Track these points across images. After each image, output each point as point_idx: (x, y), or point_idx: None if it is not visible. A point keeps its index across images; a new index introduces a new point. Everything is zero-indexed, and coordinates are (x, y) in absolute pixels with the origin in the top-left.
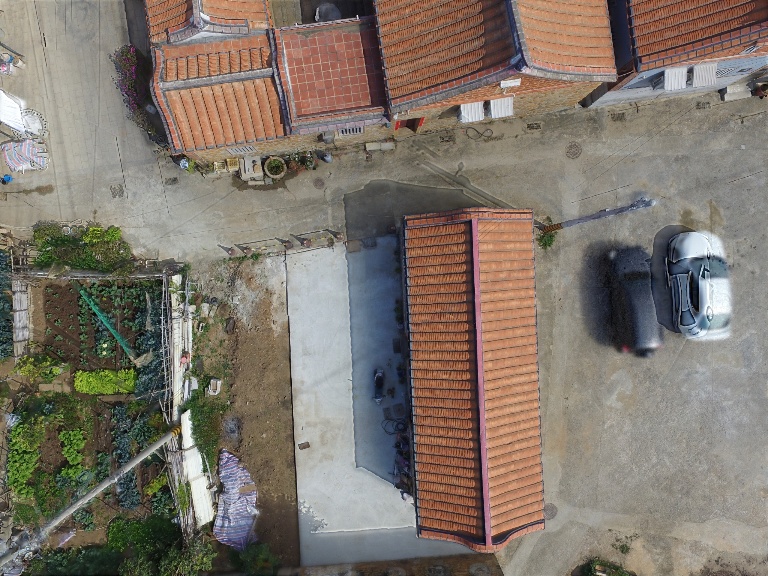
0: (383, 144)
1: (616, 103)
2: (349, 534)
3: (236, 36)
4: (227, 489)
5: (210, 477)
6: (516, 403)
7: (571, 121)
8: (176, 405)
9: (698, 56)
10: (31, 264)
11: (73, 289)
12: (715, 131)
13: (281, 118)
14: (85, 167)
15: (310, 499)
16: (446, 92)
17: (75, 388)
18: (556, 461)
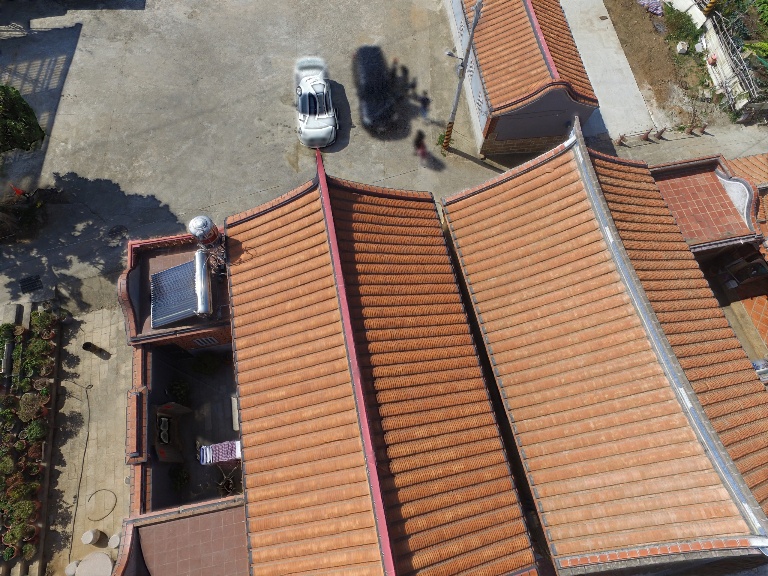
0: None
1: None
2: None
3: None
4: None
5: (665, 1)
6: None
7: None
8: (710, 30)
9: None
10: None
11: None
12: None
13: None
14: None
15: None
16: None
17: None
18: (418, 6)
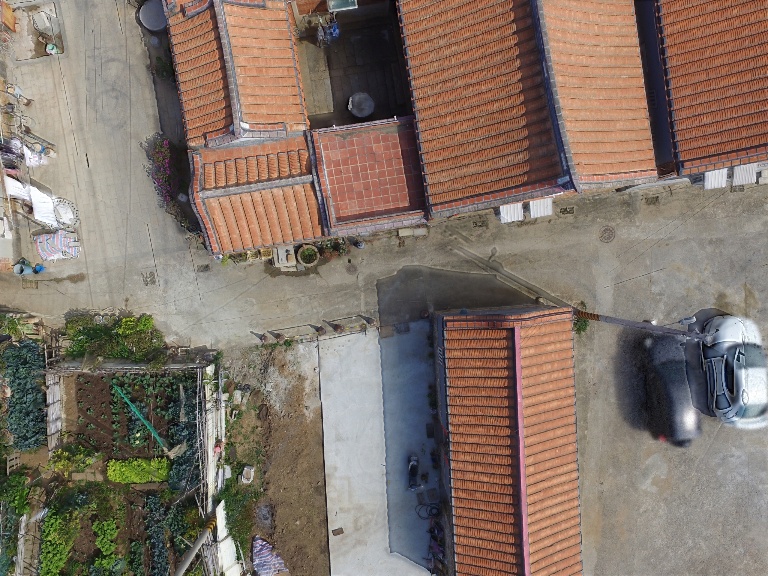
0: (416, 230)
1: (650, 187)
2: None
3: (274, 139)
4: None
5: (244, 564)
6: (557, 504)
7: (604, 205)
8: (210, 496)
9: (742, 164)
10: (63, 354)
11: (105, 378)
12: (749, 214)
13: (319, 220)
14: (116, 255)
15: None
16: (489, 202)
17: (108, 477)
18: (591, 546)
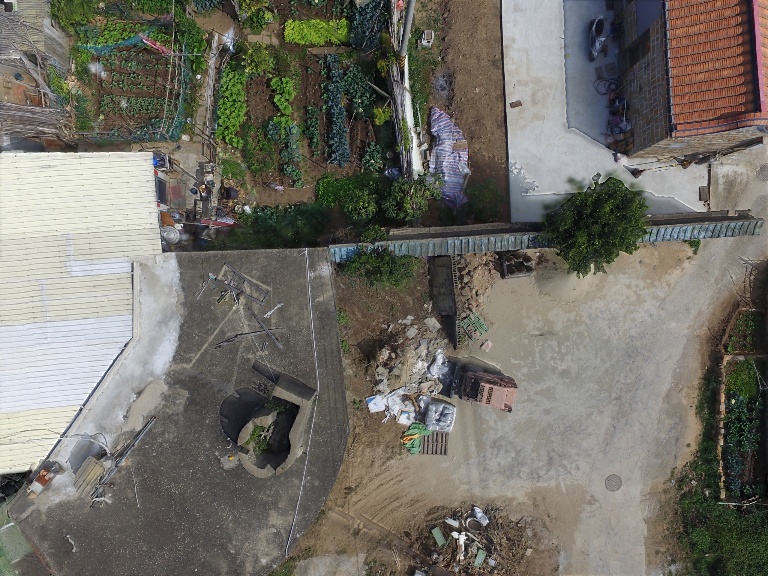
0: None
1: None
2: (561, 197)
3: None
4: (443, 139)
5: (421, 135)
6: None
7: None
8: (395, 46)
9: None
10: None
11: None
12: None
13: None
14: None
15: (521, 160)
16: None
17: (285, 38)
18: None
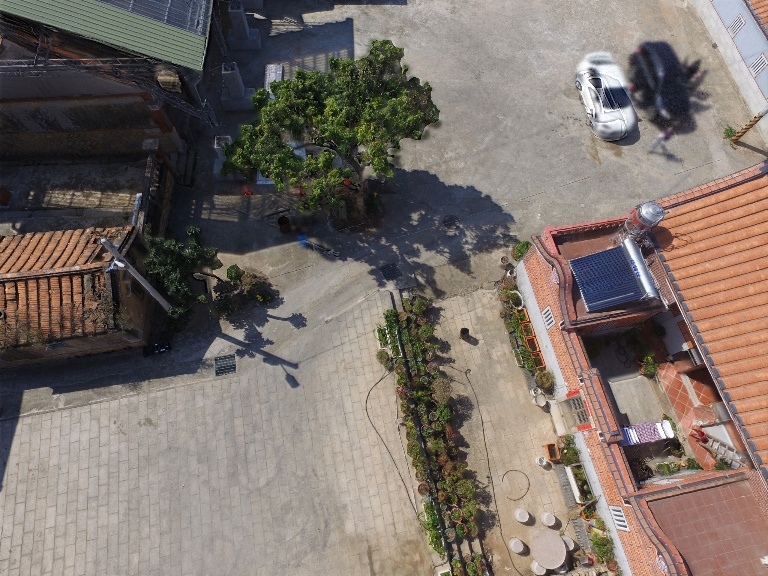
0: None
1: None
2: None
3: None
4: None
5: None
6: None
7: None
8: None
9: None
10: None
11: None
12: None
13: None
14: None
15: None
16: None
17: None
18: (664, 3)
